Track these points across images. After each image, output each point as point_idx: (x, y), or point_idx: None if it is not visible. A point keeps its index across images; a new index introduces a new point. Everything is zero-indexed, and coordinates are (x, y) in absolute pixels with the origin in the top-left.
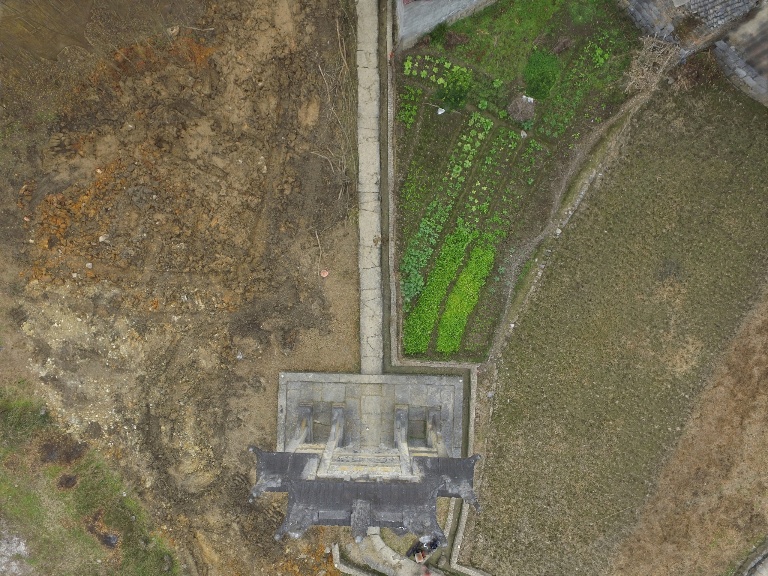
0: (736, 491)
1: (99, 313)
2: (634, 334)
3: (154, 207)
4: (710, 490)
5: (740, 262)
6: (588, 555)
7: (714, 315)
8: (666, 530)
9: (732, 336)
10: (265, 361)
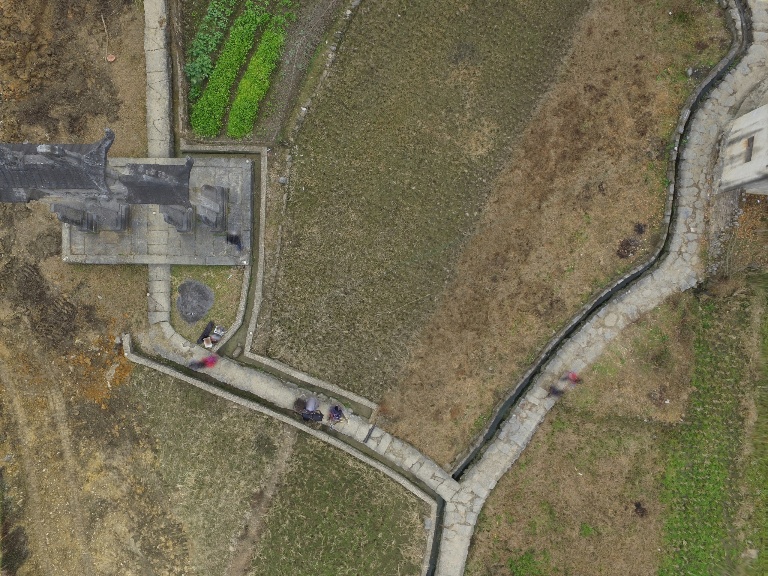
0: (535, 276)
1: None
2: (429, 118)
3: None
4: (509, 276)
5: (535, 44)
6: (387, 344)
7: (510, 97)
8: (466, 317)
9: (528, 119)
10: None
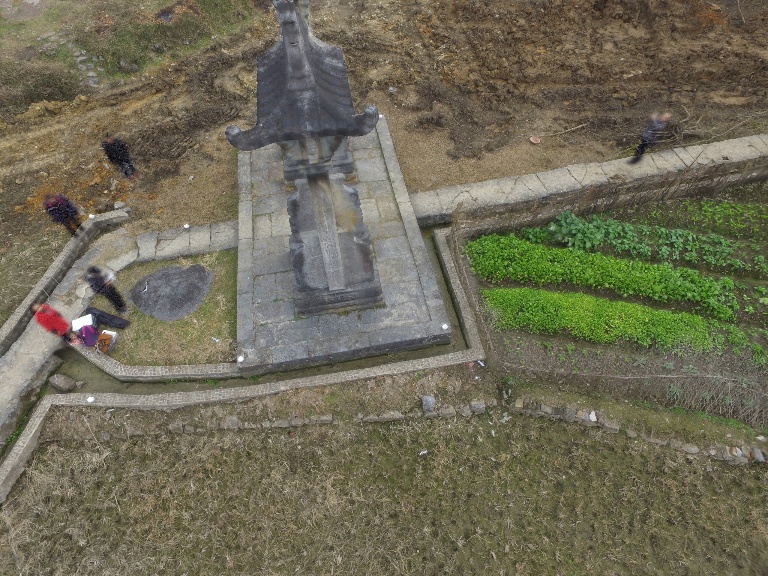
0: None
1: (403, 7)
2: None
3: (530, 15)
4: None
5: None
6: None
7: None
8: None
9: None
10: (393, 109)
